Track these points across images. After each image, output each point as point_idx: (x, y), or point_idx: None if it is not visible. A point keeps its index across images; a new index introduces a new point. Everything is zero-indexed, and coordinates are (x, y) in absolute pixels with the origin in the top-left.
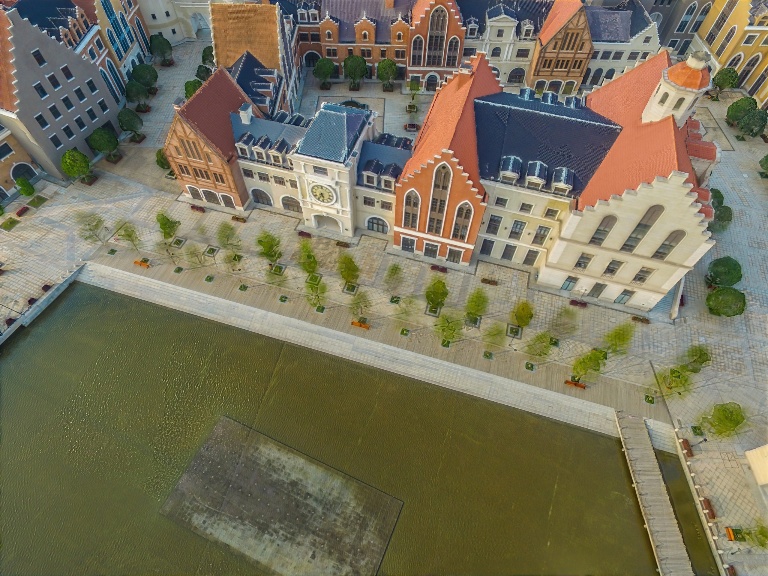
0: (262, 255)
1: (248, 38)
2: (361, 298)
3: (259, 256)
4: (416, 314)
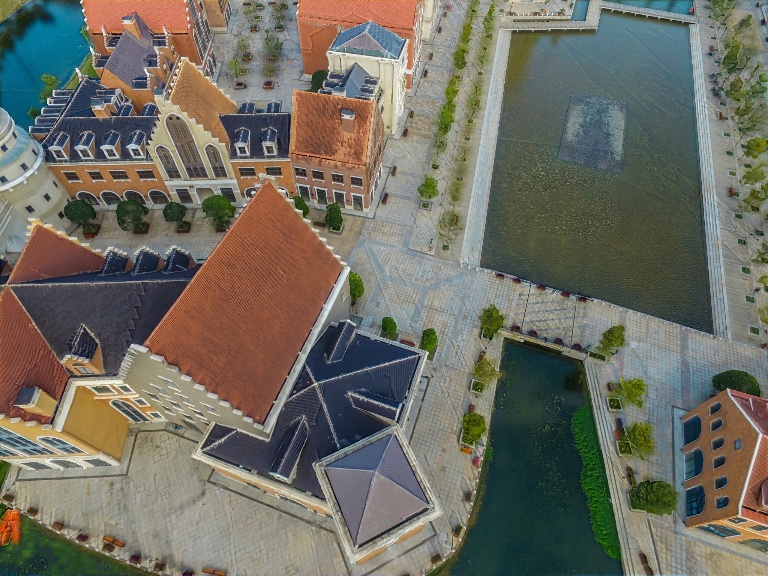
0: (429, 154)
1: (207, 104)
2: (457, 105)
3: (431, 155)
4: (463, 84)
